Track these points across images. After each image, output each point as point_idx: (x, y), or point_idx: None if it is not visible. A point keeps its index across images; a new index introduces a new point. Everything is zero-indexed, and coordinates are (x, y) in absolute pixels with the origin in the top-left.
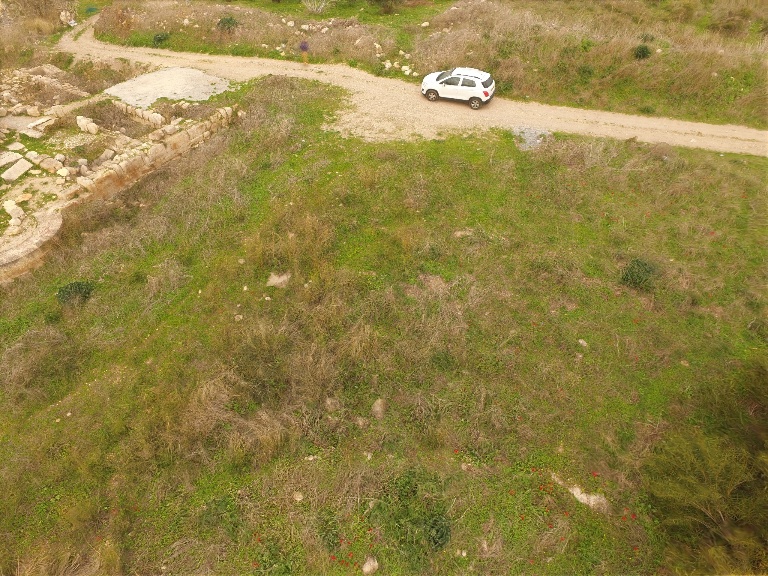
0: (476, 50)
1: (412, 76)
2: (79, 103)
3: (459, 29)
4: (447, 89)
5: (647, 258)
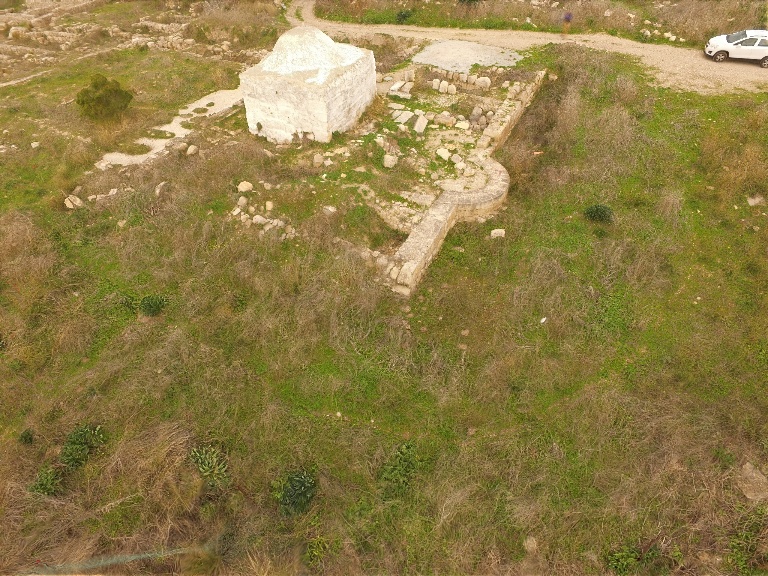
0: (739, 16)
1: (680, 42)
2: (403, 70)
3: (678, 1)
4: (741, 50)
5: None
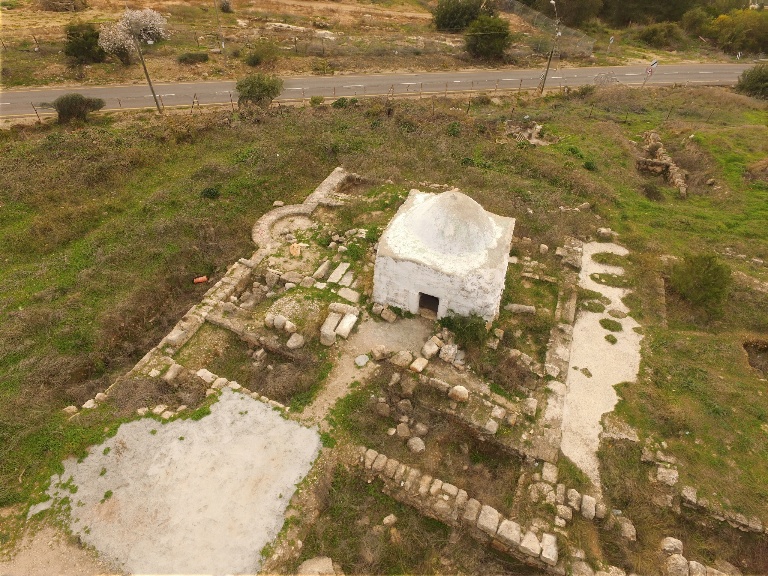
0: None
1: None
2: (337, 391)
3: None
4: None
5: None
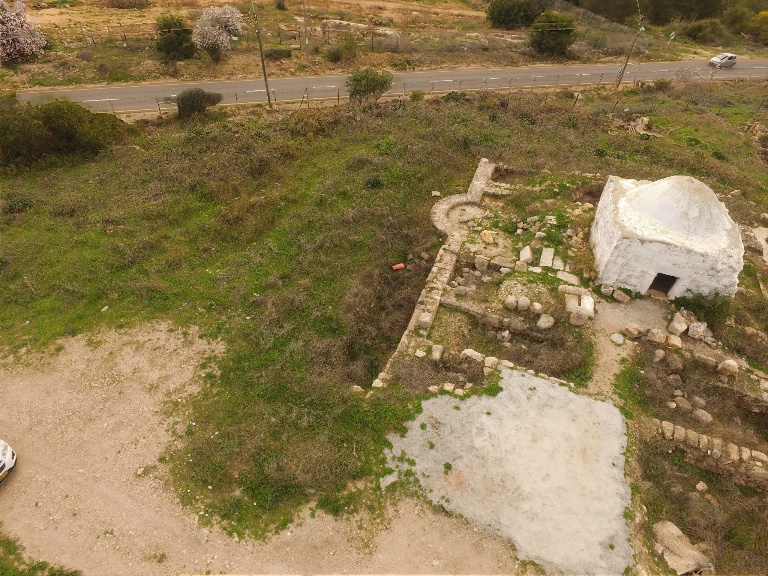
0: None
1: None
2: (611, 367)
3: None
4: None
5: (2, 207)
